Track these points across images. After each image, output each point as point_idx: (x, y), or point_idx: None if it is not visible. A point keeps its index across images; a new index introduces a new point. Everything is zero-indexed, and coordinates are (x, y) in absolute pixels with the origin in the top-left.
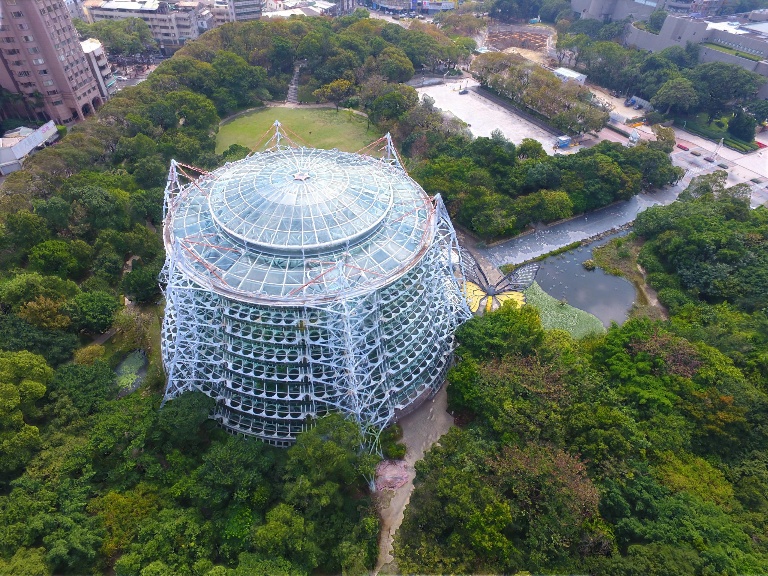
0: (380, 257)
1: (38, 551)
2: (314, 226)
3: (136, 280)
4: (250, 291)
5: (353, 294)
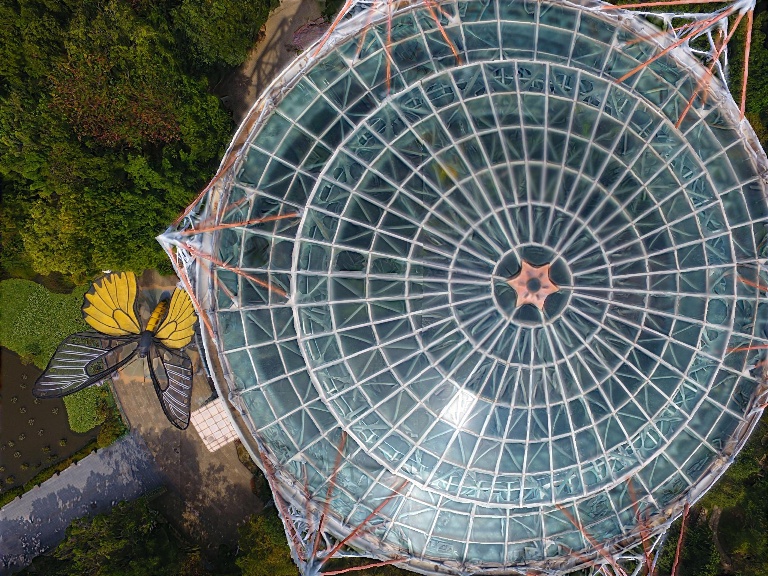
0: (319, 118)
1: None
2: (467, 113)
3: None
4: (557, 6)
5: (366, 18)
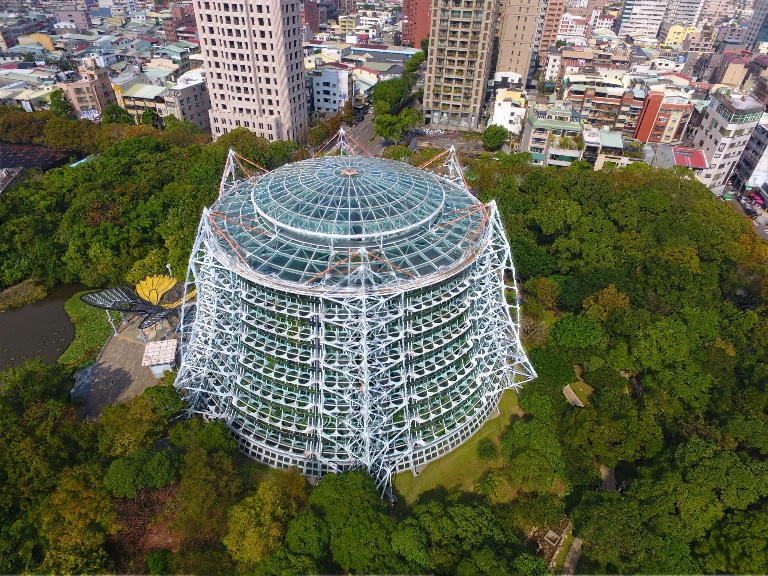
0: None
1: (497, 194)
2: None
3: (550, 348)
4: None
5: None
